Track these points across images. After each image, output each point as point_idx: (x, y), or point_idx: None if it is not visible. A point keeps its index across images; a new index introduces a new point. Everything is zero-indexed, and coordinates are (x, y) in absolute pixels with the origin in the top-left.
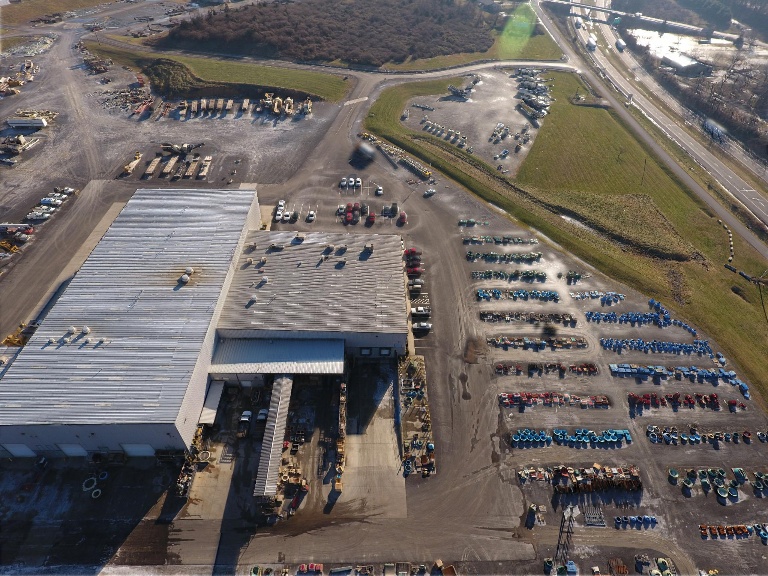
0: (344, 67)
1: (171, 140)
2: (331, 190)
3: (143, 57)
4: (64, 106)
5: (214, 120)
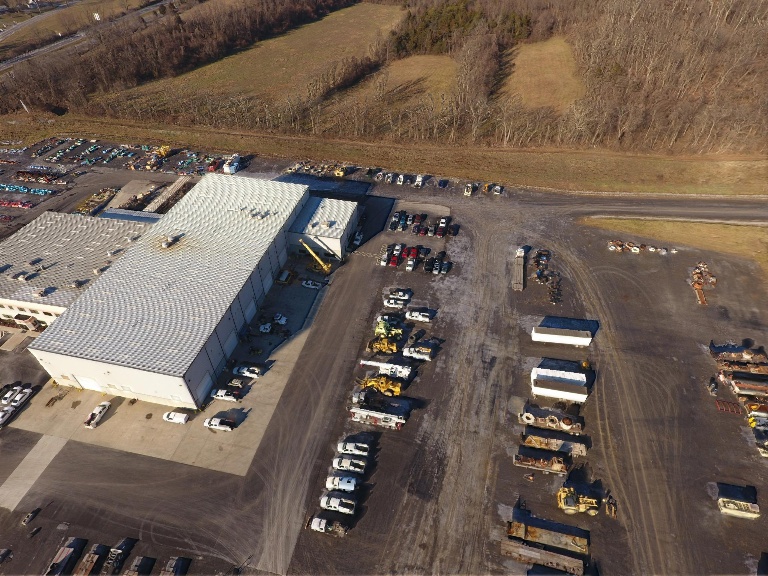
0: None
1: None
2: None
3: None
4: None
5: None
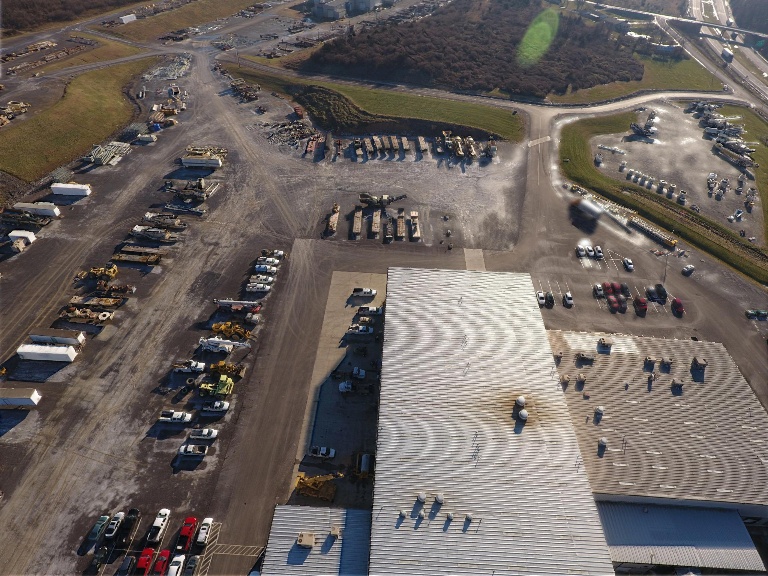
0: (506, 98)
1: (359, 187)
2: (571, 261)
3: (292, 83)
4: (229, 141)
5: (395, 162)
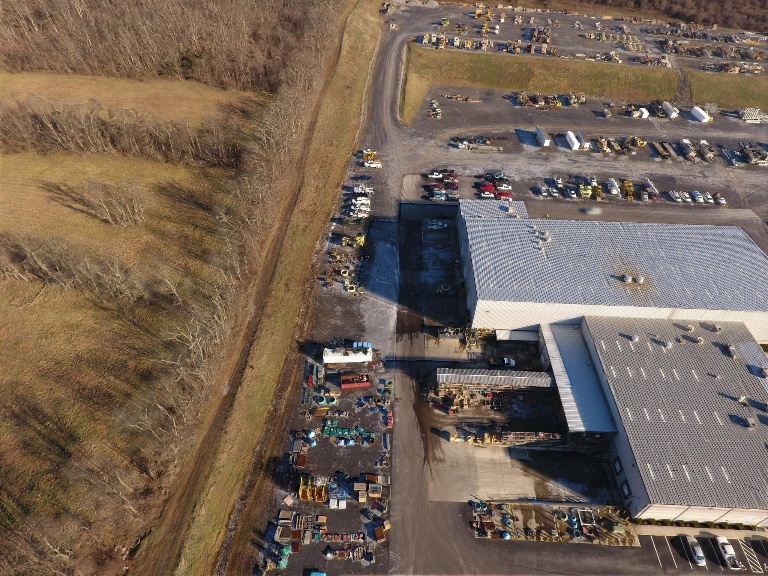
0: None
1: None
2: None
3: None
4: None
5: None
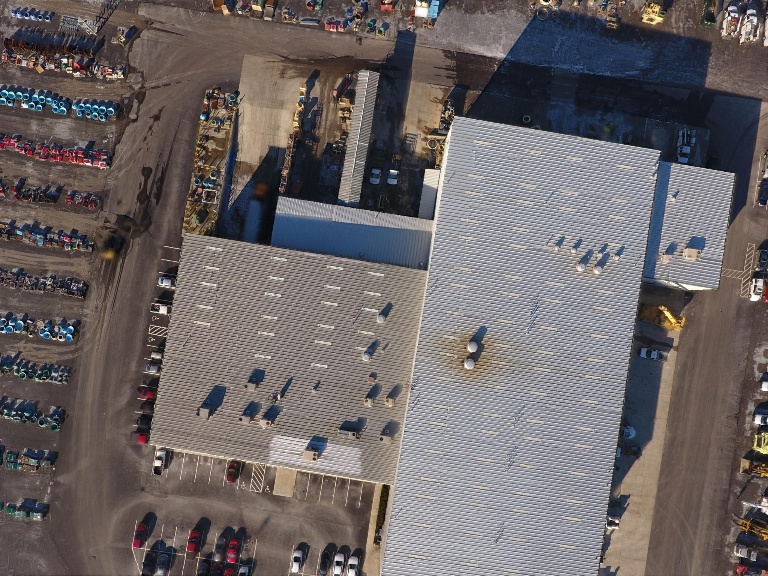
0: None
1: None
2: None
3: None
4: None
5: None
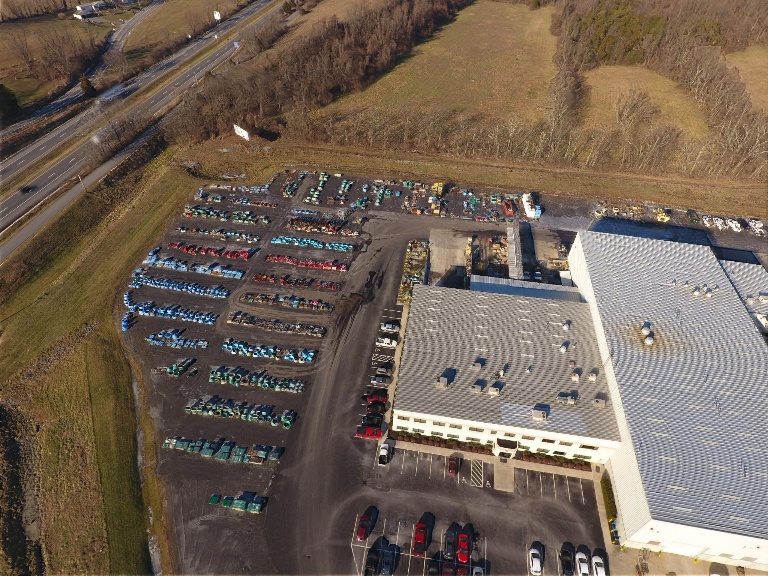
0: None
1: None
2: None
3: None
4: None
5: None
